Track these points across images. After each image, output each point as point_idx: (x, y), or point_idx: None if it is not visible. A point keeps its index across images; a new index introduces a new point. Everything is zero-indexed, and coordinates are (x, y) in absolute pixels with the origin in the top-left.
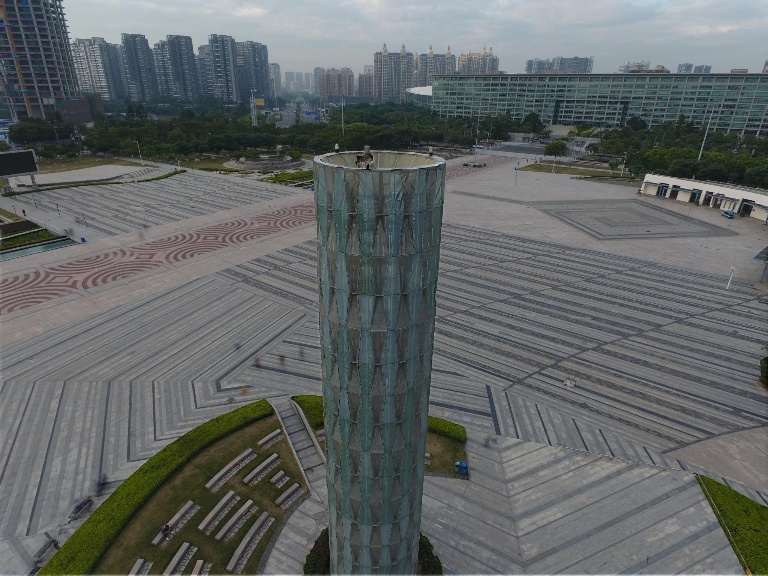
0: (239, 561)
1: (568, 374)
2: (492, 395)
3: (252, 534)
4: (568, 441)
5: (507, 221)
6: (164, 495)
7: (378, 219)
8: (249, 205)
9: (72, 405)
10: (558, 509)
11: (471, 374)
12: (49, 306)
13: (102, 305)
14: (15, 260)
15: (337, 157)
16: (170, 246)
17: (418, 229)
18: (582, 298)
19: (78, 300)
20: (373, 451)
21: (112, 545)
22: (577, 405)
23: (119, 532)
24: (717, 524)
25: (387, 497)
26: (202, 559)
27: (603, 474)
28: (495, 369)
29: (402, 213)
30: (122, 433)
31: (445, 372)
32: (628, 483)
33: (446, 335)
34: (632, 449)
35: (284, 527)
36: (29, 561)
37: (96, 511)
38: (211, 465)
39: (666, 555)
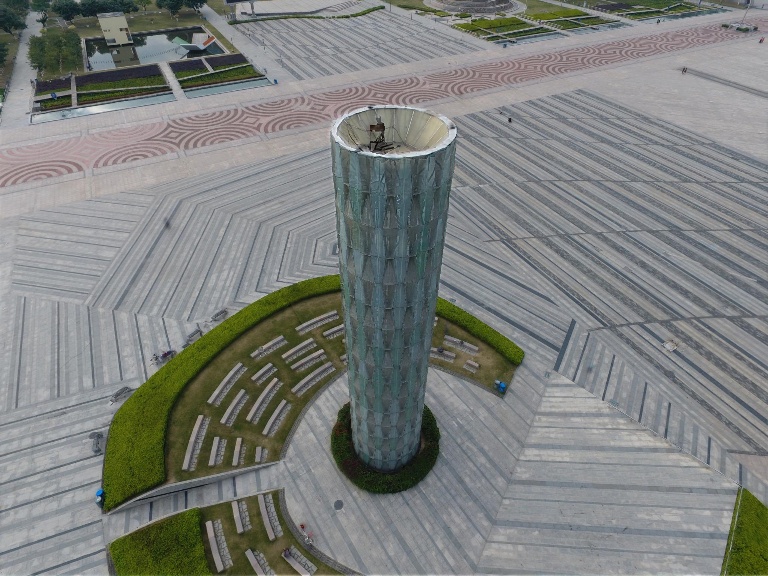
0: (301, 388)
1: (675, 336)
2: (573, 331)
3: (315, 374)
4: (625, 401)
5: (731, 124)
6: (267, 325)
7: (366, 194)
8: (430, 59)
9: (232, 236)
10: (569, 454)
11: (564, 304)
12: (237, 144)
13: (273, 152)
14: (224, 95)
15: (371, 112)
16: (342, 99)
17: (404, 208)
18: (764, 252)
19: (258, 143)
20: (367, 362)
21: (227, 347)
22: (662, 371)
23: (233, 341)
24: (725, 536)
25: (379, 395)
26: (278, 378)
27: (636, 444)
28: (593, 306)
29: (385, 194)
30: (258, 268)
31: (538, 294)
32: (657, 462)
33: (561, 255)
34: (693, 434)
35: (340, 377)
36: (185, 338)
37: (226, 320)
38: (304, 314)
39: (647, 534)
